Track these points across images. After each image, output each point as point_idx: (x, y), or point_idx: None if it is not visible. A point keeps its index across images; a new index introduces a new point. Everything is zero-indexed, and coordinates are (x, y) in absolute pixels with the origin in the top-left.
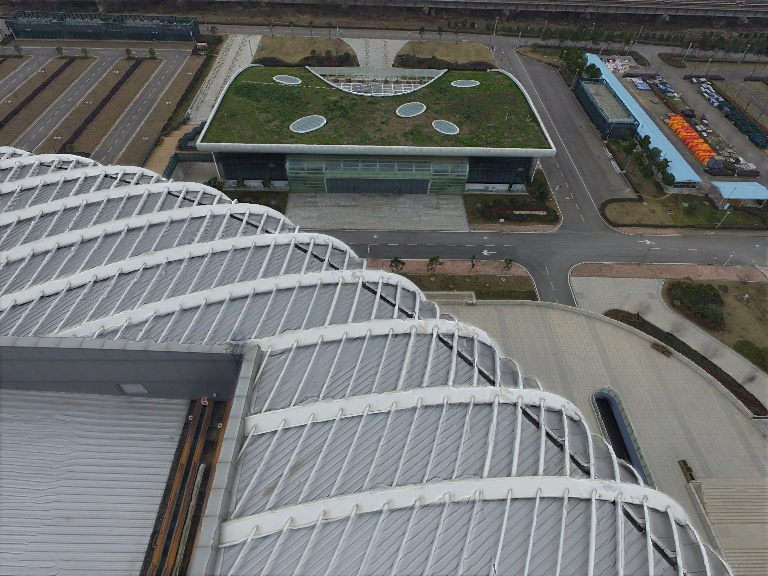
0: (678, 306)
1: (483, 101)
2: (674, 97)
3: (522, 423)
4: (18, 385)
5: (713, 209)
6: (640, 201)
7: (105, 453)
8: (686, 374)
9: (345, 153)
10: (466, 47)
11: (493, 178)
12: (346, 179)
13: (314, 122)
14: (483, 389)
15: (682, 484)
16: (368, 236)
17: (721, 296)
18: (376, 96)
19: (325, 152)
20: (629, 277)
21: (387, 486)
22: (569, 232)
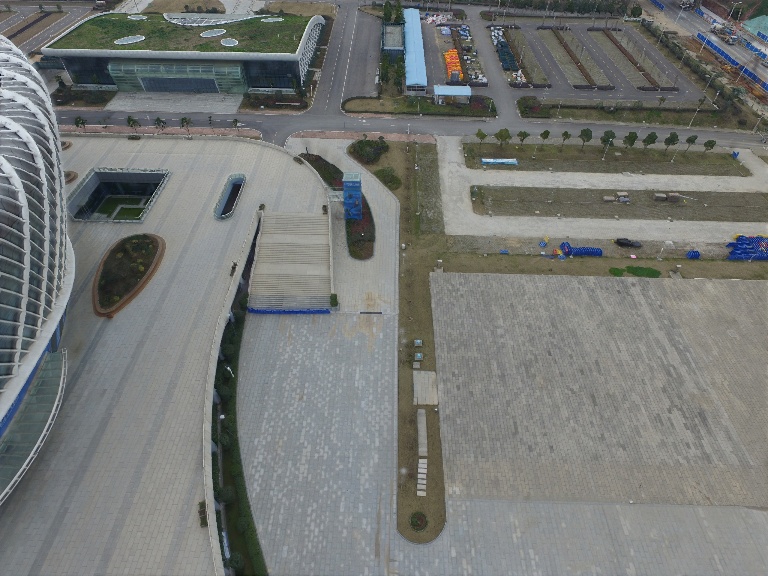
0: (352, 152)
1: (274, 29)
2: (466, 39)
3: None
4: None
5: (431, 104)
6: (377, 99)
7: None
8: (304, 172)
9: (148, 57)
10: (318, 5)
11: None
12: (154, 78)
13: (134, 39)
14: None
15: None
16: (161, 115)
17: (389, 148)
18: (194, 25)
19: (133, 56)
20: (332, 138)
21: None
22: (309, 115)
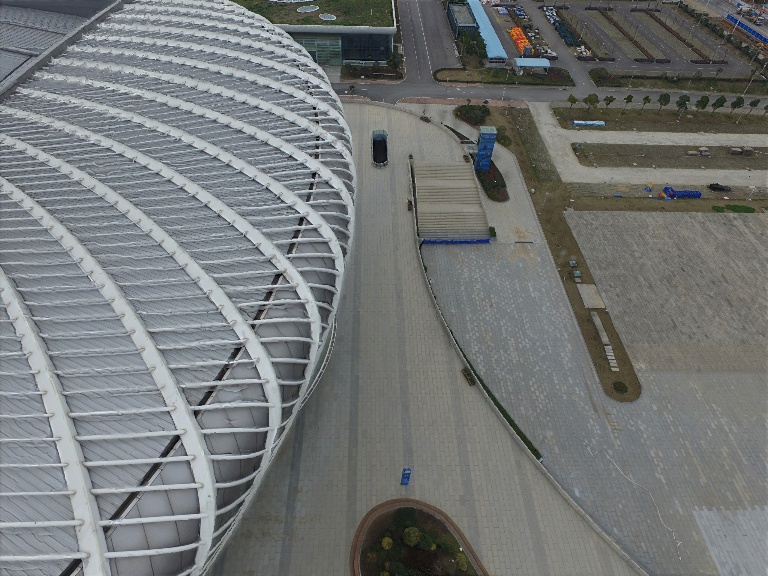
0: (459, 115)
1: (361, 6)
2: (524, 18)
3: (239, 13)
4: (58, 10)
5: (513, 75)
6: (463, 70)
7: None
8: (434, 129)
9: None
10: None
11: (364, 56)
12: None
13: None
14: (229, 7)
15: (406, 163)
16: None
17: (490, 112)
18: (286, 2)
19: None
20: (436, 104)
21: (179, 7)
22: (407, 84)
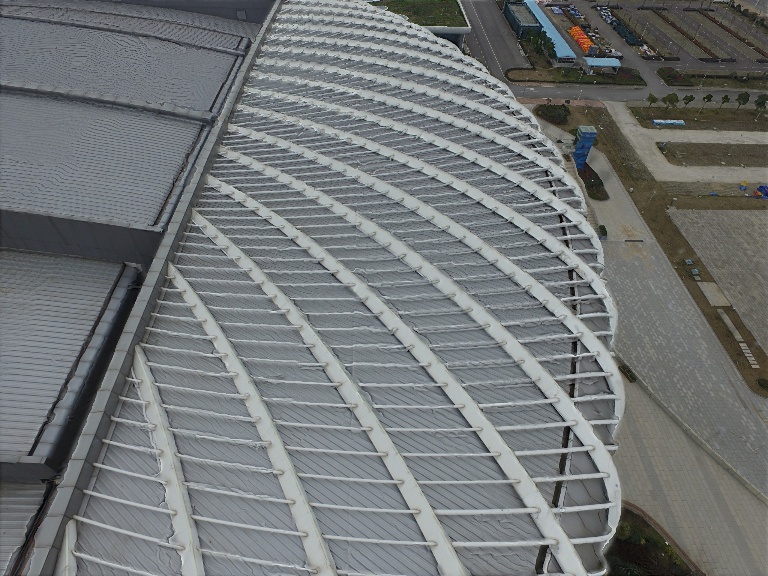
0: (540, 114)
1: (428, 6)
2: (580, 18)
3: None
4: (200, 10)
5: (583, 74)
6: (533, 70)
7: (234, 29)
8: None
9: None
10: None
11: None
12: None
13: None
14: (370, 7)
15: None
16: None
17: (570, 111)
18: None
19: None
20: None
21: None
22: None
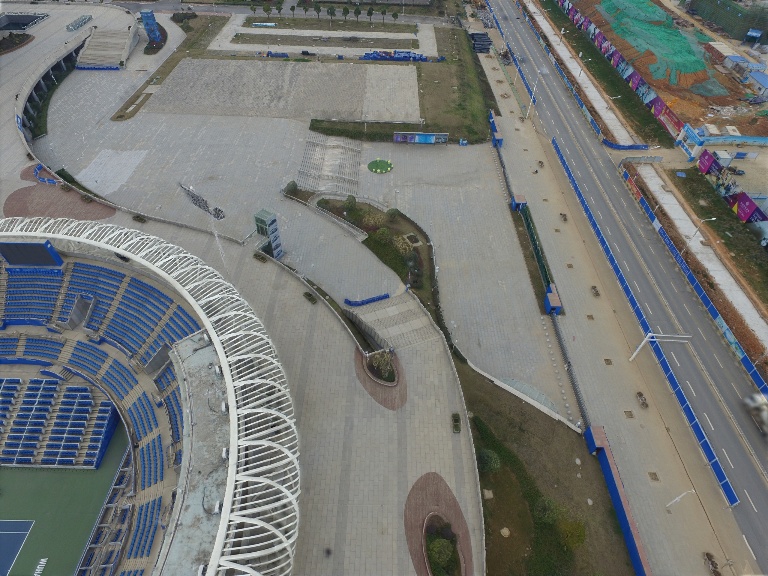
0: (172, 18)
1: None
2: None
3: None
4: None
5: (241, 0)
6: None
7: None
8: None
9: None
10: None
11: None
12: None
13: None
14: None
15: None
16: None
17: (198, 17)
18: None
19: None
20: (165, 13)
21: None
22: None
